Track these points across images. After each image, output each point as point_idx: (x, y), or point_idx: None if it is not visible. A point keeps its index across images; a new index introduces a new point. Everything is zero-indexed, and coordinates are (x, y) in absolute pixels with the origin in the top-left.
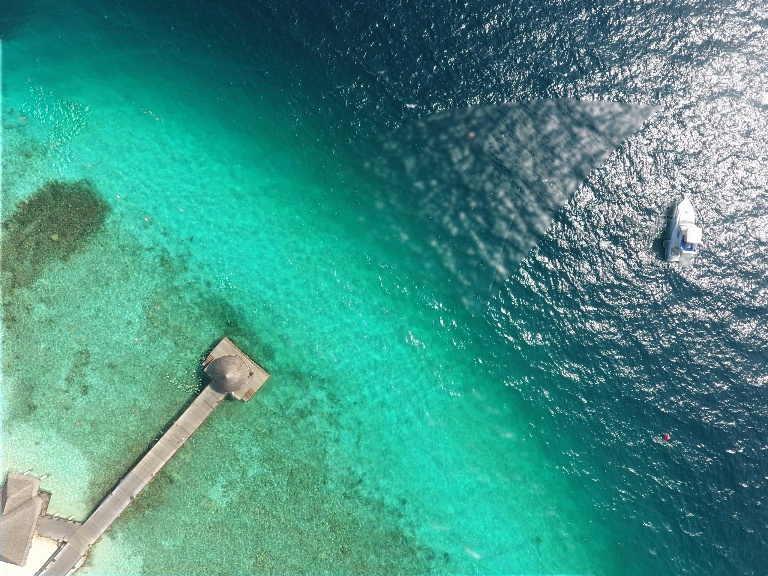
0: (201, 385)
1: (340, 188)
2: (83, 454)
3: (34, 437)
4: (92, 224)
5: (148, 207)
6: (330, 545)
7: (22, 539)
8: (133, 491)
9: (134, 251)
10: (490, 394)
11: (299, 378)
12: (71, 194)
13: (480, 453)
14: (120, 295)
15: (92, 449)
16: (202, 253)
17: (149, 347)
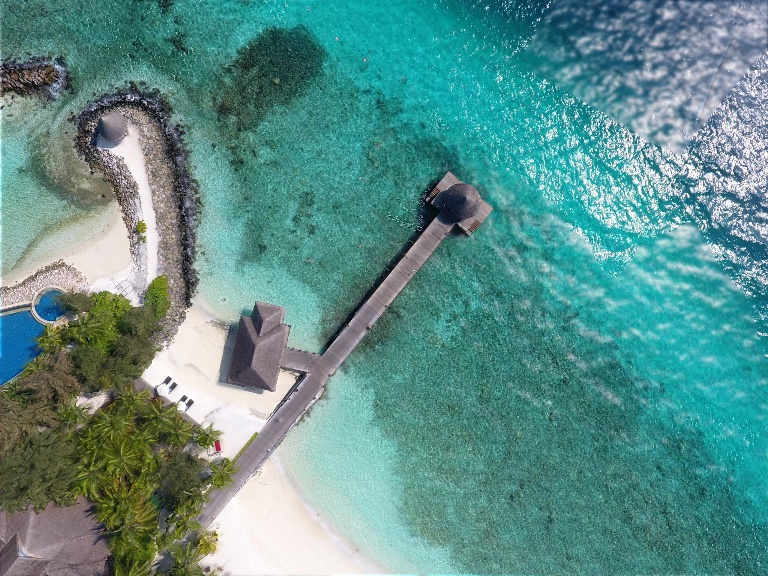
0: (423, 222)
1: (545, 28)
2: (313, 291)
3: (266, 276)
4: (311, 67)
5: (364, 49)
6: (552, 376)
7: (274, 363)
8: (368, 322)
9: (352, 93)
10: (693, 231)
11: (513, 216)
12: (289, 39)
13: (689, 286)
14: (340, 137)
15: (321, 287)
16: (416, 95)
17: (370, 187)
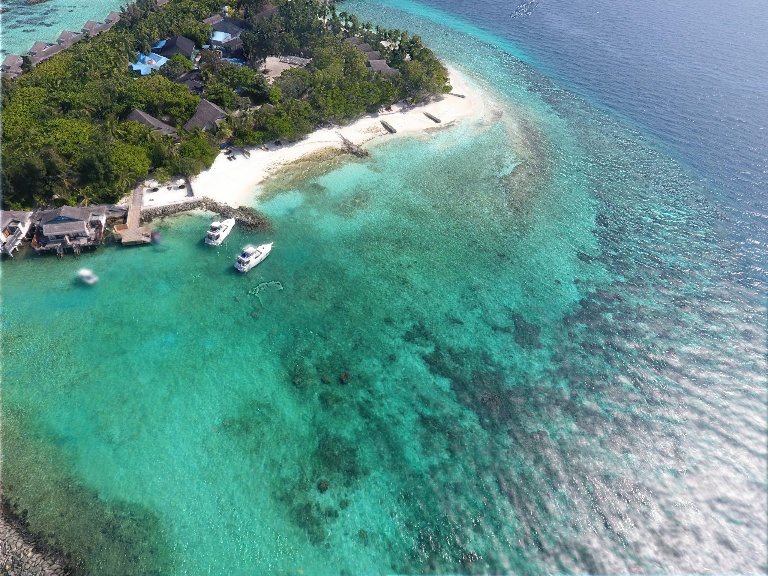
0: None
1: None
2: None
3: None
4: None
5: None
6: None
7: None
8: None
9: None
10: None
11: None
12: None
13: None
14: None
15: None
16: None
17: None
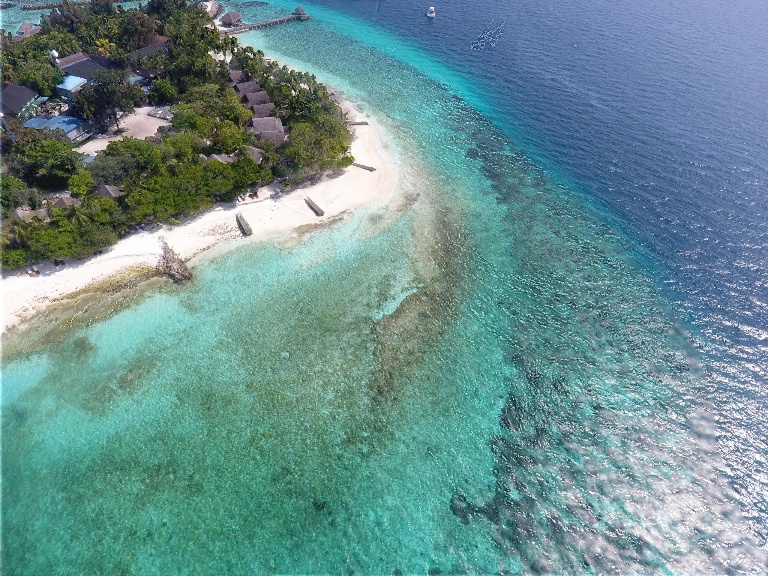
0: None
1: None
2: None
3: None
4: (264, 4)
5: None
6: None
7: (235, 18)
8: None
9: None
10: None
11: None
12: None
13: None
14: None
15: None
16: None
17: None
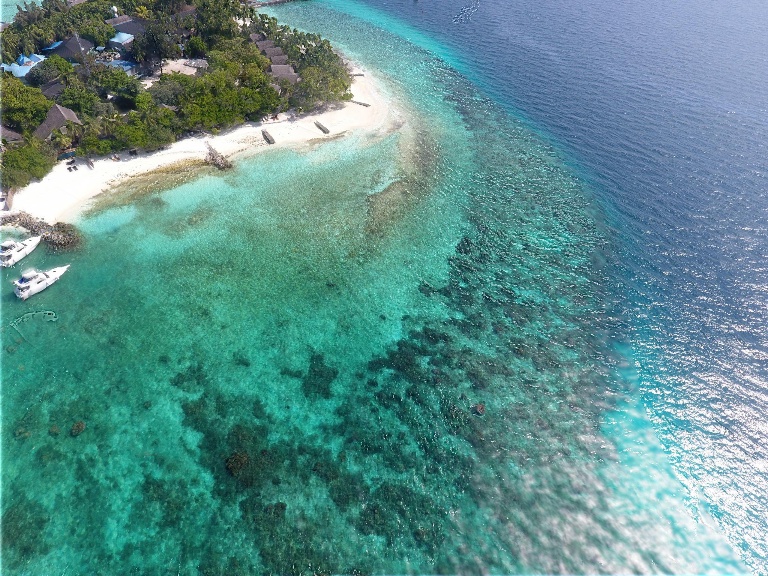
0: None
1: None
2: None
3: None
4: None
5: None
6: None
7: None
8: None
9: None
10: None
11: (321, 2)
12: None
13: None
14: None
15: None
16: None
17: None
